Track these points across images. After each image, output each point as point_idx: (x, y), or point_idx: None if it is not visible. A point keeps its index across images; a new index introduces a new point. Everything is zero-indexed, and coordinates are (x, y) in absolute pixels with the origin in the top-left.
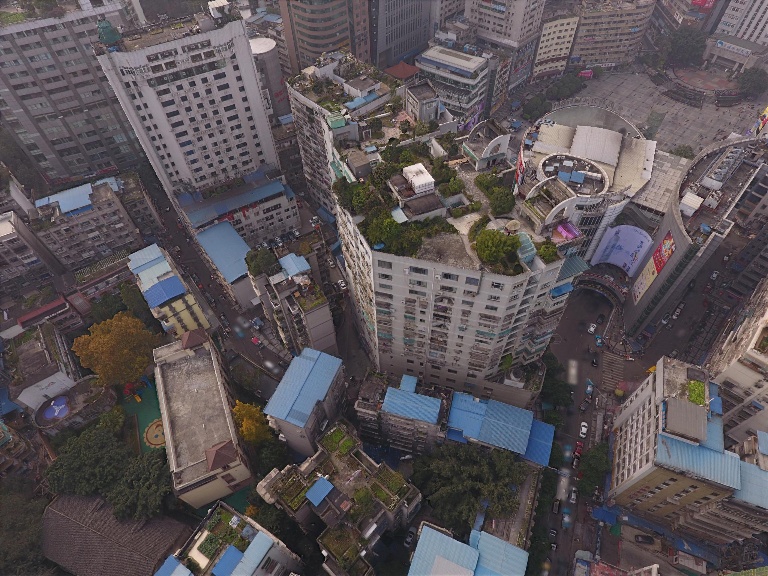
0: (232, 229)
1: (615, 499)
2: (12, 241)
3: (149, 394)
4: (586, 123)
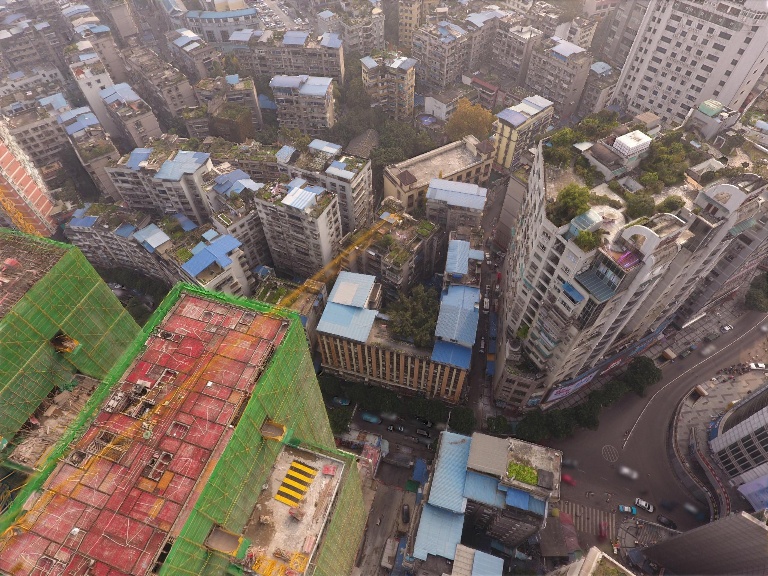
0: None
1: None
2: (521, 44)
3: None
4: None
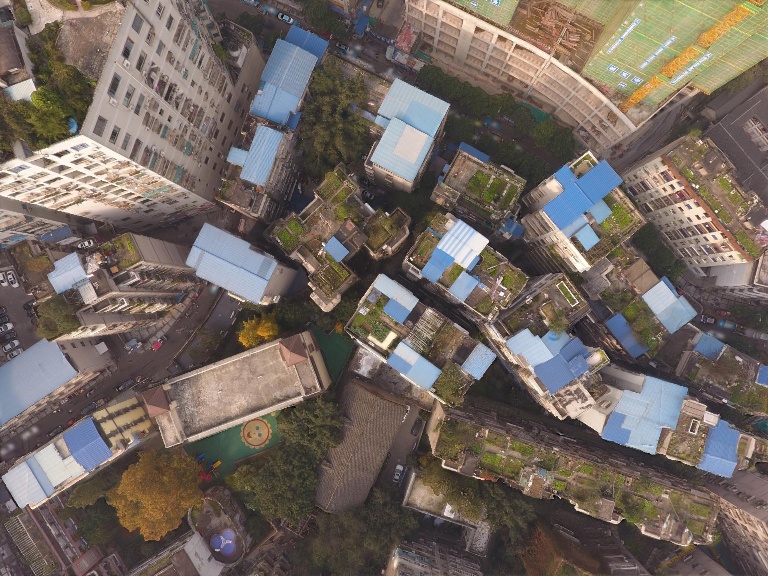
0: None
1: (351, 8)
2: None
3: (213, 454)
4: None
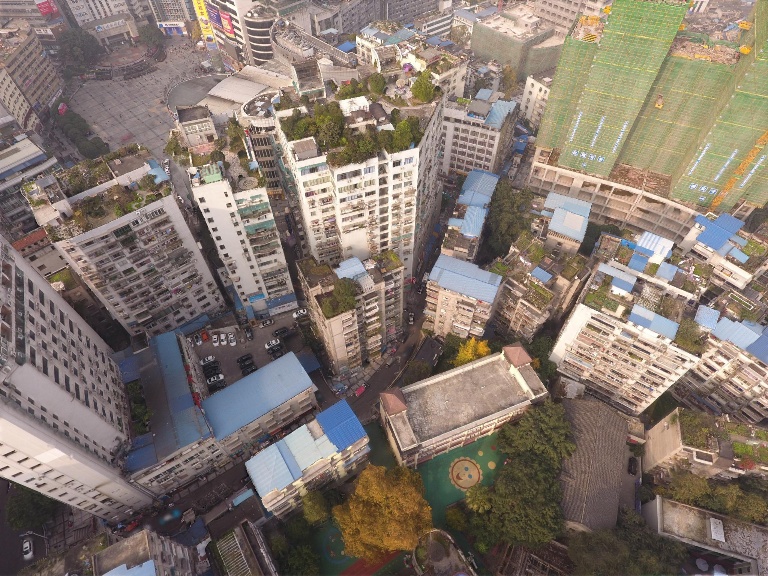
0: (219, 394)
1: None
2: None
3: None
4: (196, 94)
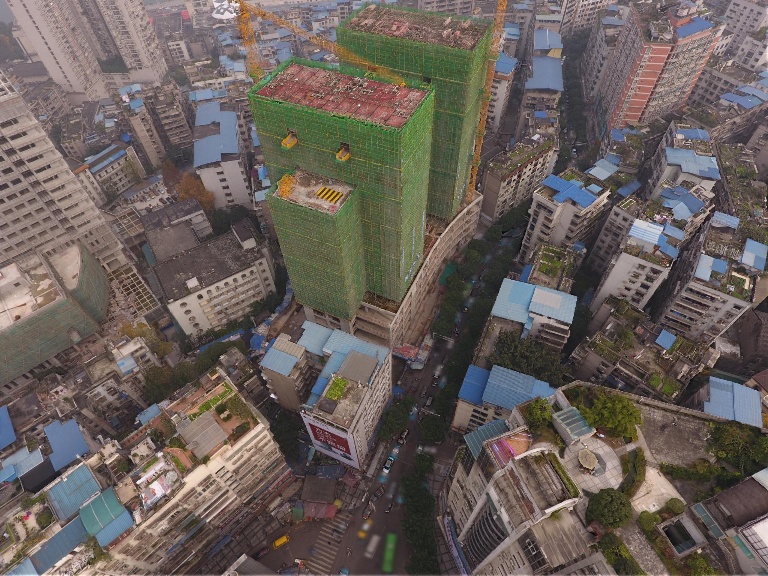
0: None
1: None
2: None
3: None
4: None
